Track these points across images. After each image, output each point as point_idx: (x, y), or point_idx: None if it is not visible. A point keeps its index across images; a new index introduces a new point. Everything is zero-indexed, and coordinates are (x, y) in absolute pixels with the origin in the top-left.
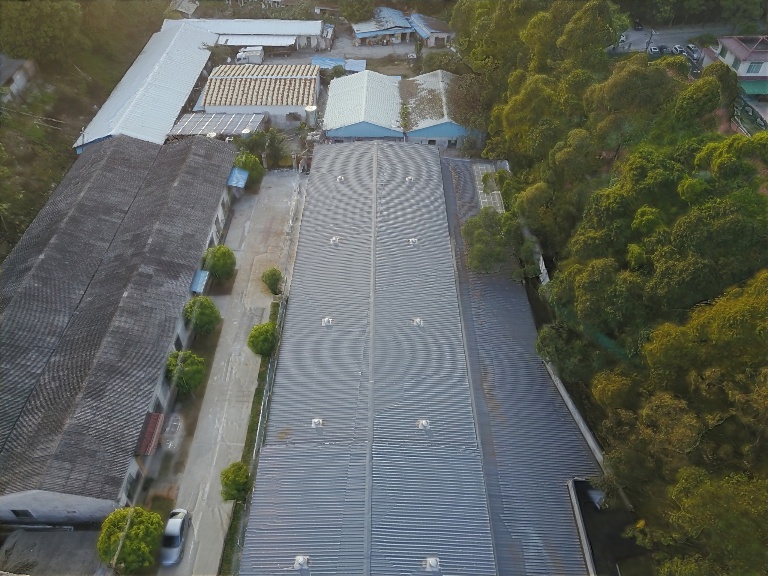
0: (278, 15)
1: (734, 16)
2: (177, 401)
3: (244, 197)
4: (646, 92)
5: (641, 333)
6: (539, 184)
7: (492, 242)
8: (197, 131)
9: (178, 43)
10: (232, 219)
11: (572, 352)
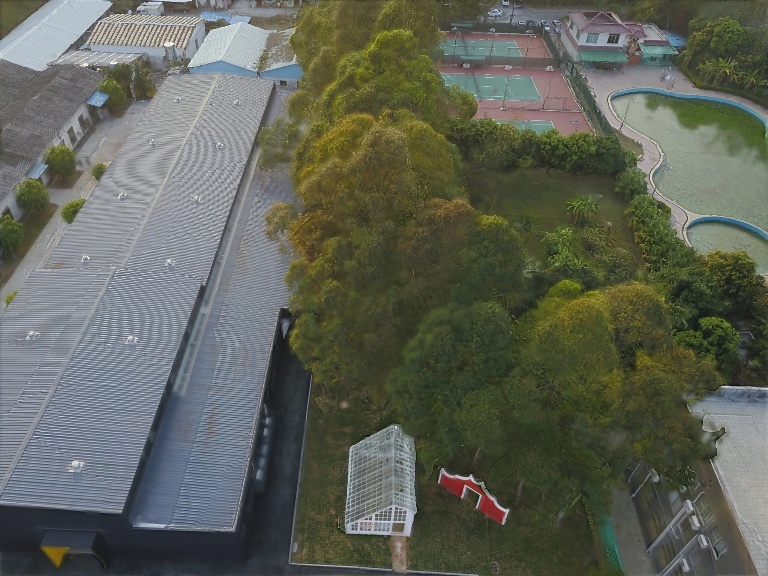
0: None
1: None
2: (0, 259)
3: (108, 119)
4: (362, 11)
5: None
6: None
7: (278, 145)
8: (74, 63)
9: None
10: (91, 135)
11: None
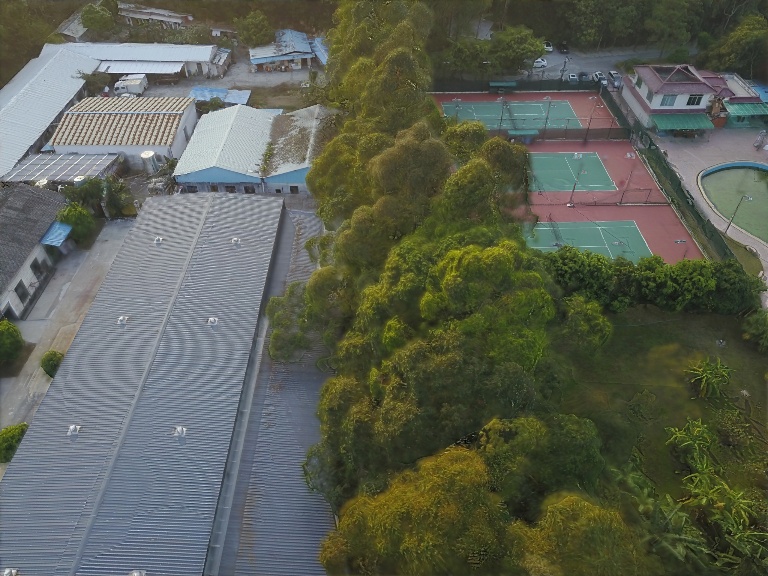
0: (172, 38)
1: (659, 41)
2: None
3: (73, 253)
4: (416, 172)
5: (363, 488)
6: (323, 269)
7: (293, 326)
8: (31, 177)
9: (48, 72)
10: (50, 280)
11: (342, 477)
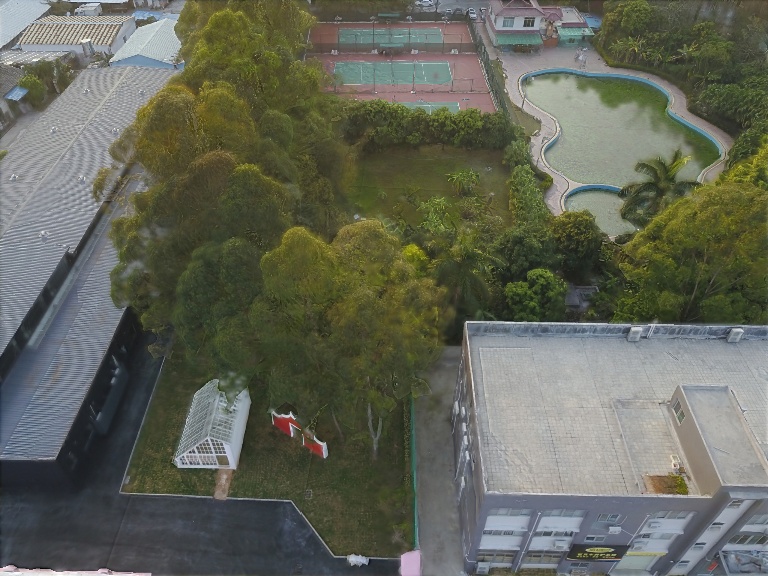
0: None
1: None
2: None
3: (30, 113)
4: None
5: None
6: None
7: None
8: (1, 61)
9: None
10: (12, 127)
11: None
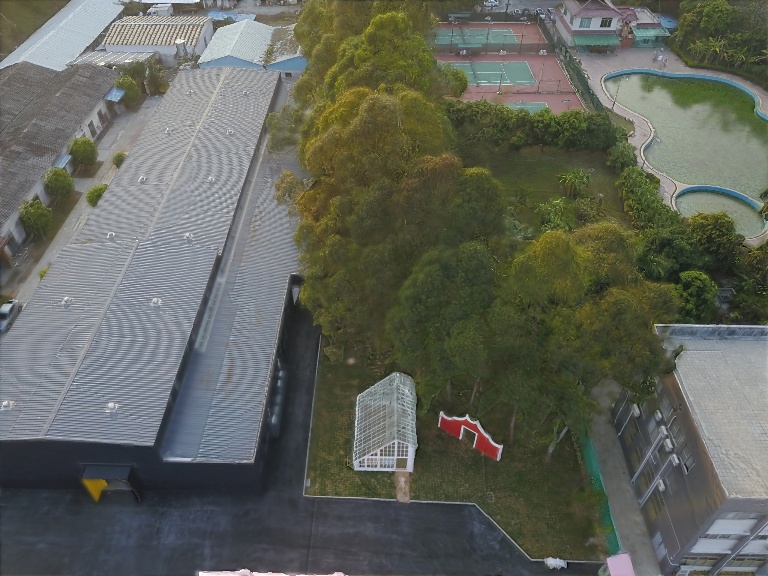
0: None
1: None
2: (32, 242)
3: (124, 114)
4: None
5: None
6: None
7: (284, 129)
8: (91, 62)
9: None
10: (110, 128)
11: None
